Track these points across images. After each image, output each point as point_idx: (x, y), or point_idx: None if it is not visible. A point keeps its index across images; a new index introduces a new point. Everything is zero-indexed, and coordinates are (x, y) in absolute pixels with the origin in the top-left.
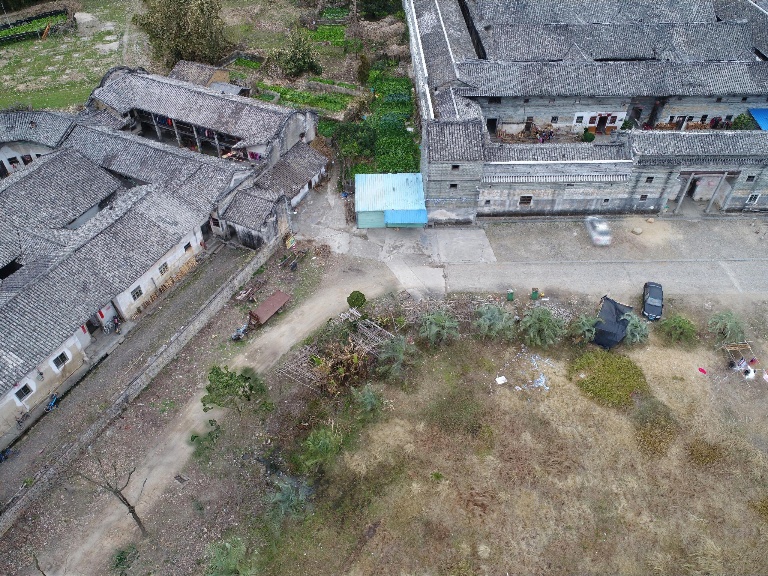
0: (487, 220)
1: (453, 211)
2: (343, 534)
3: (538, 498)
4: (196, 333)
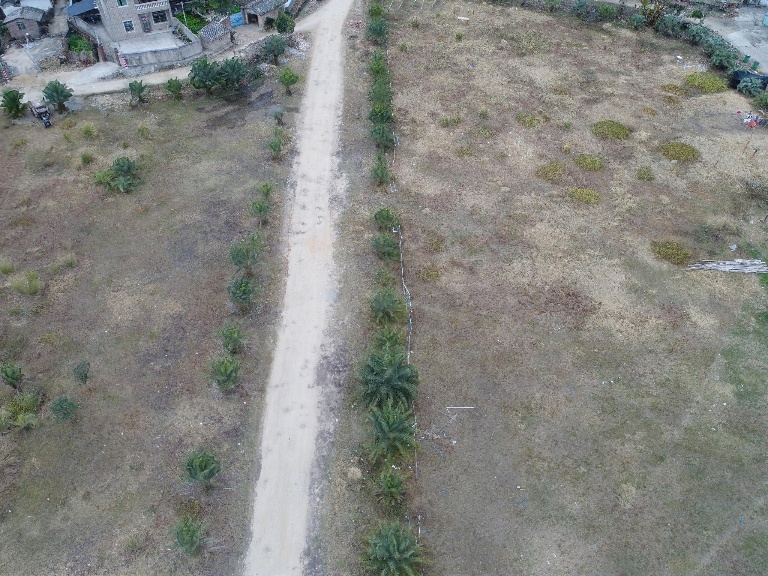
0: None
1: None
2: None
3: None
4: None
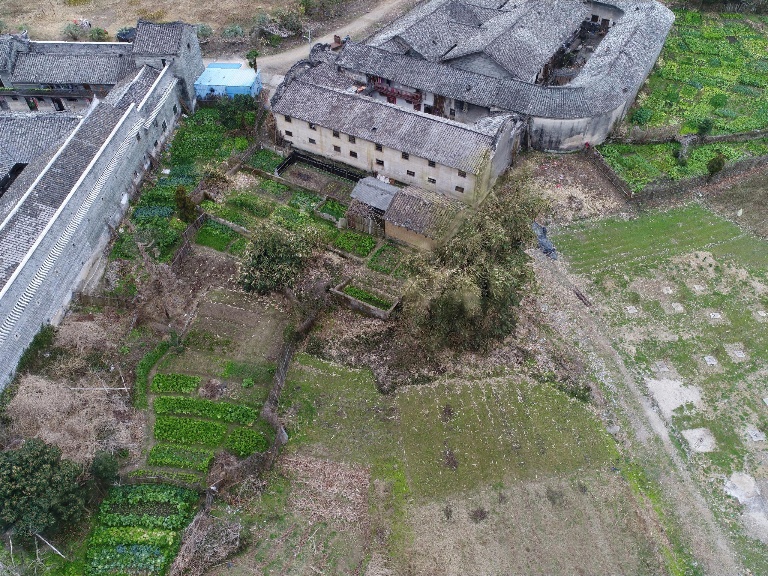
0: None
1: None
2: None
3: None
4: None
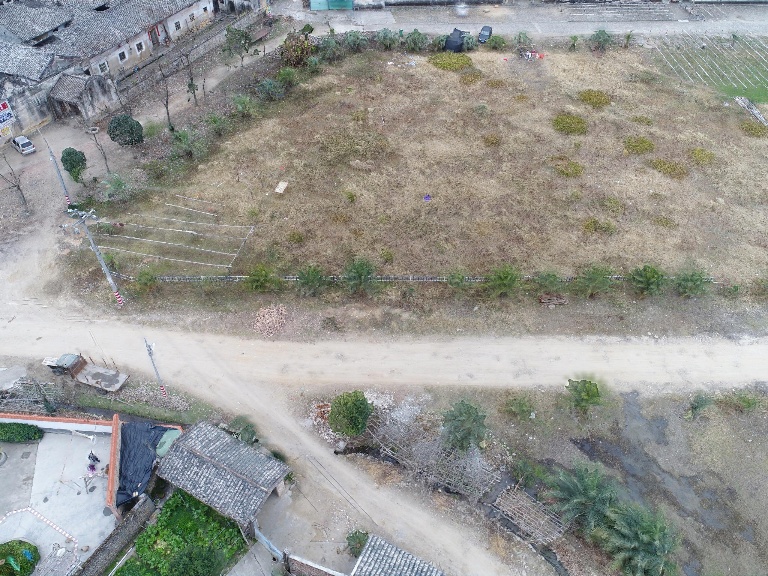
0: (393, 8)
1: None
2: (299, 106)
3: (402, 97)
4: (214, 48)
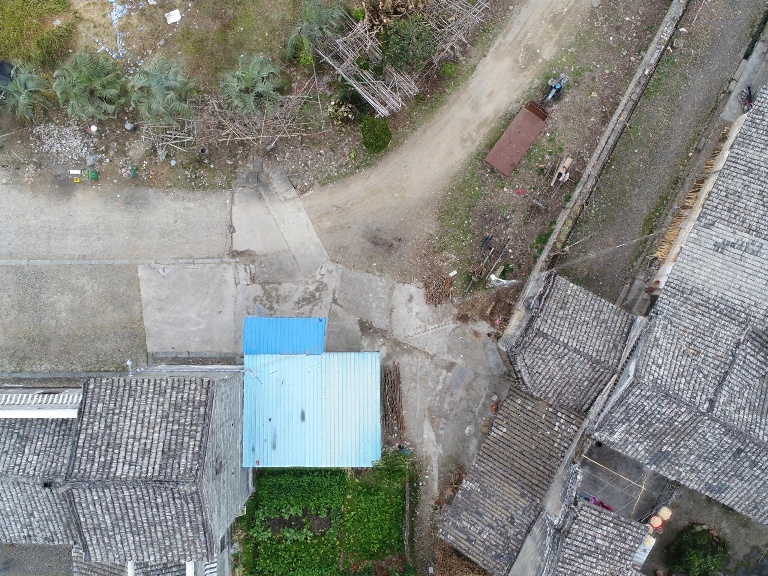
0: None
1: (194, 368)
2: None
3: None
4: None
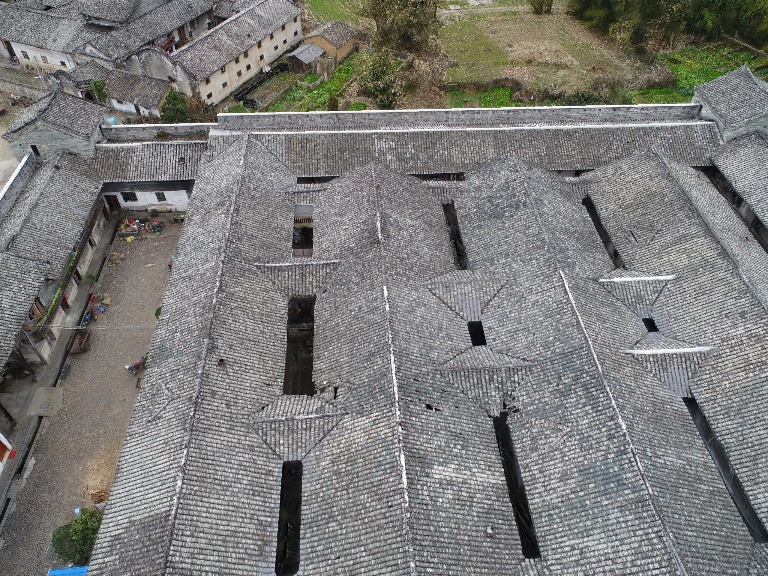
0: None
1: None
2: None
3: None
4: None
